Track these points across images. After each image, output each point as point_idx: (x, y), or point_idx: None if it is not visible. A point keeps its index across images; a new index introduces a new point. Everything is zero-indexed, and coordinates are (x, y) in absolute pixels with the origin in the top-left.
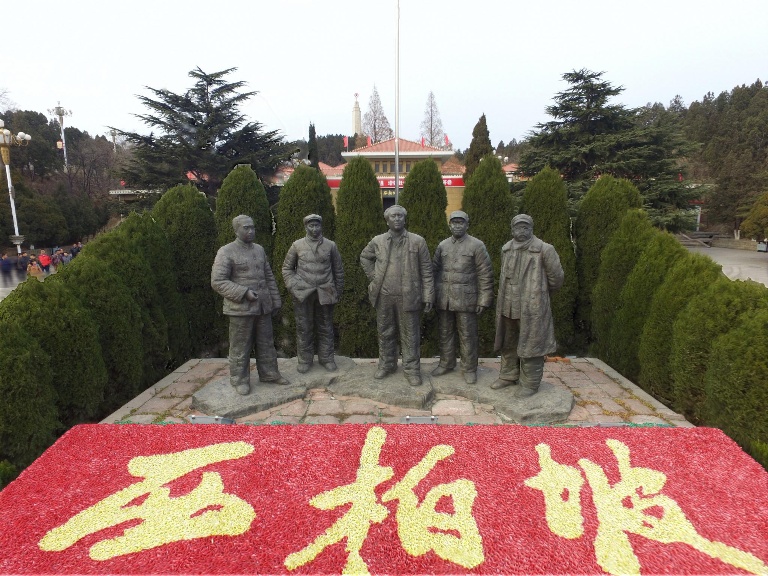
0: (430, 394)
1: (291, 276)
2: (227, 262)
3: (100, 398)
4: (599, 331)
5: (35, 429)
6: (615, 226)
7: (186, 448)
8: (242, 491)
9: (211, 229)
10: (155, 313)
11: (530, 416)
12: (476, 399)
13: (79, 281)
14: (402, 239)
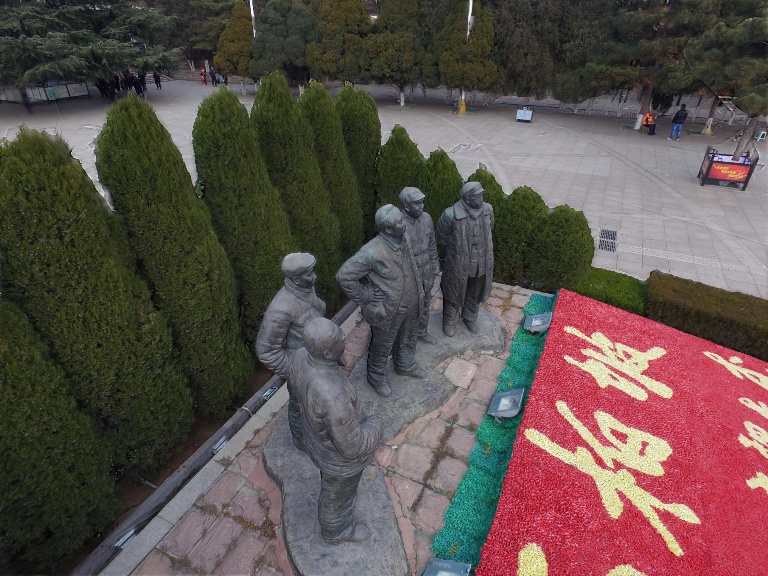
0: None
1: (287, 357)
2: (353, 408)
3: None
4: None
5: None
6: (374, 140)
7: None
8: (598, 570)
9: None
10: None
11: None
12: (458, 353)
13: None
14: (405, 244)
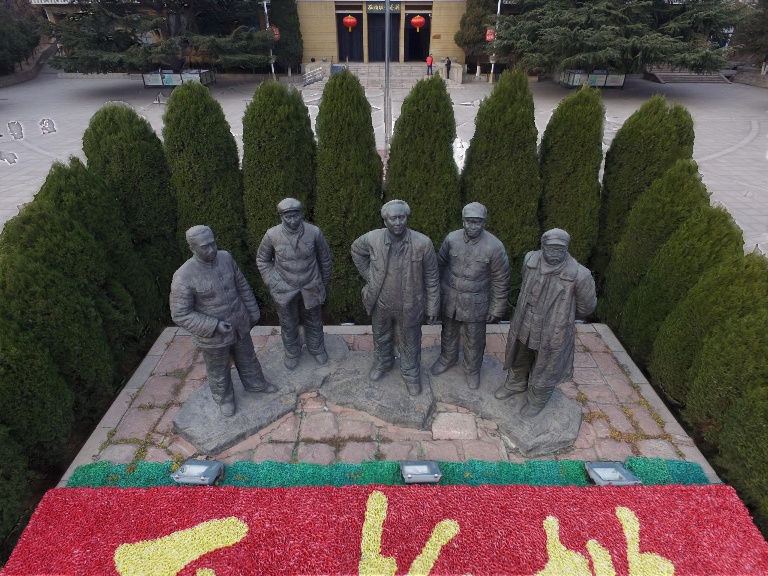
0: (430, 407)
1: (268, 270)
2: (187, 292)
3: (71, 420)
4: (612, 293)
5: (3, 504)
6: (655, 170)
7: (174, 529)
8: None
9: (162, 165)
10: (113, 292)
11: (536, 447)
12: (479, 413)
13: (7, 296)
14: (403, 245)
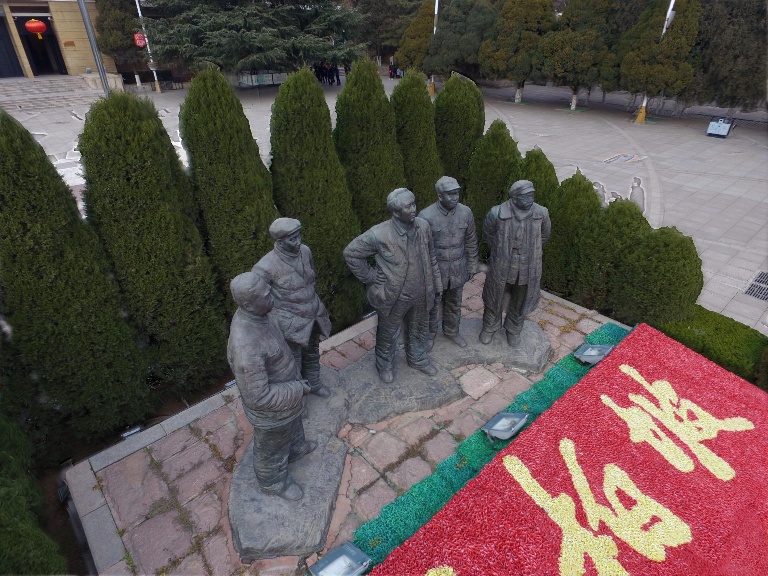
0: None
1: None
2: (263, 362)
3: None
4: None
5: None
6: (472, 133)
7: None
8: None
9: None
10: None
11: None
12: (484, 362)
13: None
14: (416, 231)
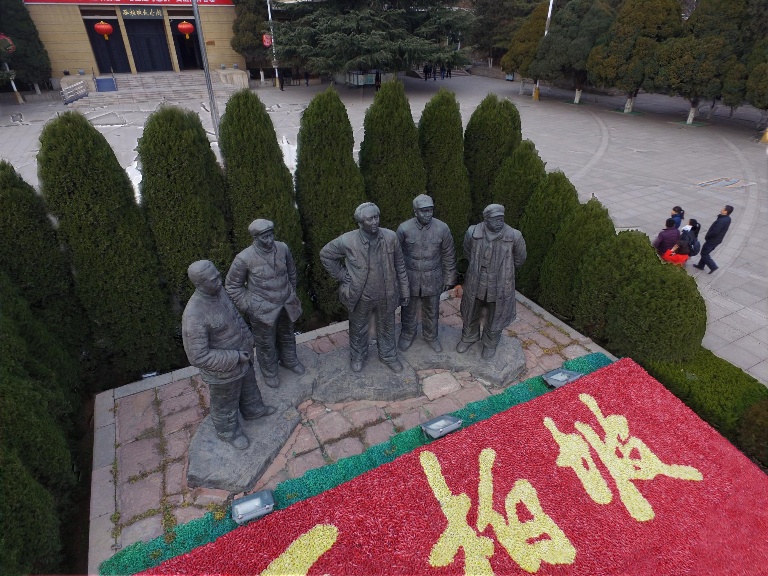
0: None
1: (243, 295)
2: (204, 331)
3: (57, 524)
4: None
5: None
6: (503, 151)
7: (268, 561)
8: None
9: (41, 213)
10: (35, 369)
11: (505, 378)
12: (453, 369)
13: None
14: (379, 241)
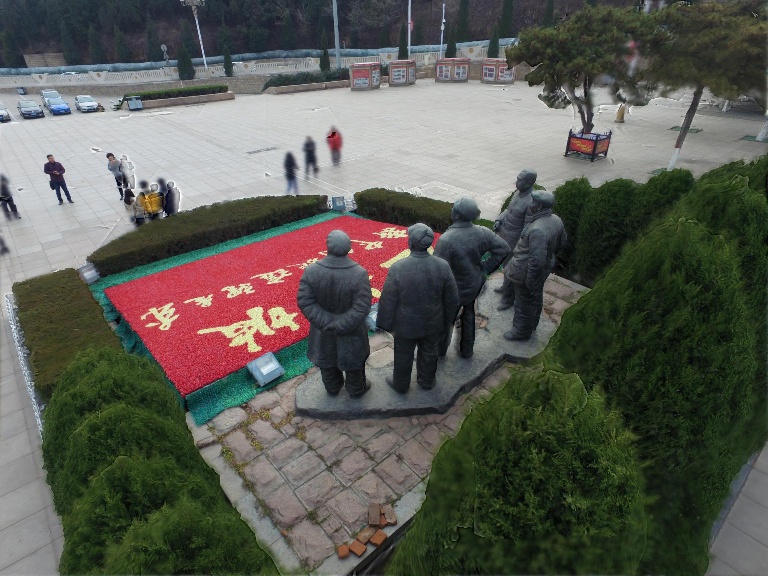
0: None
1: None
2: None
3: None
4: None
5: None
6: None
7: None
8: None
9: None
10: None
11: None
12: None
13: None
14: None
